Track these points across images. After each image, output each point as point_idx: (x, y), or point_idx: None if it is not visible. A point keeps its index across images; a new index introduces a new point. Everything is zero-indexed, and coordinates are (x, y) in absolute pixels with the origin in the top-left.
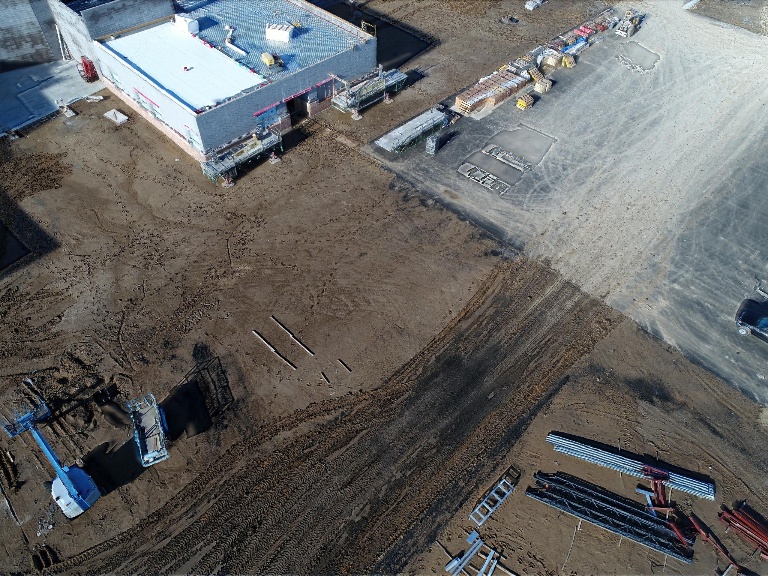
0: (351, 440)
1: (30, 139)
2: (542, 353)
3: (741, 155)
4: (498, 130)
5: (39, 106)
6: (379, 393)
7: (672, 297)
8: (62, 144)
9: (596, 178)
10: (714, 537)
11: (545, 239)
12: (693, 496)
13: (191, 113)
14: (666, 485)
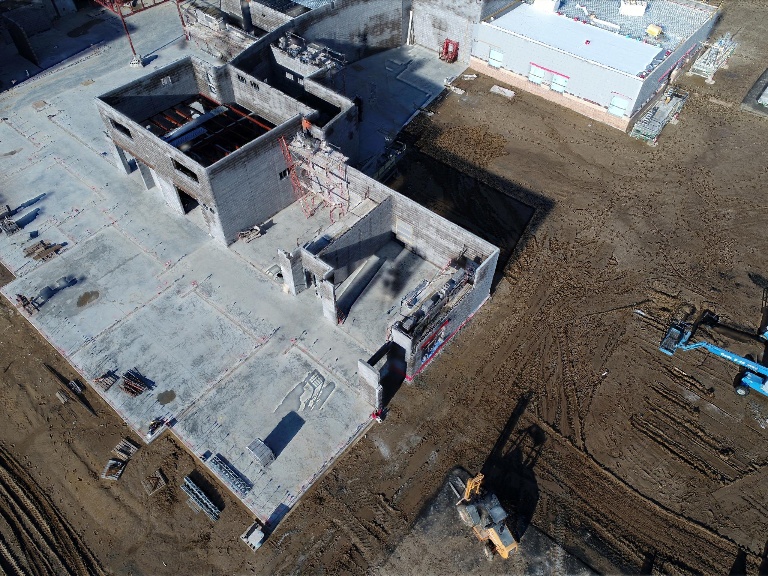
0: None
1: (443, 115)
2: None
3: None
4: None
5: (426, 86)
6: None
7: None
8: (475, 117)
9: None
10: None
11: None
12: None
13: (636, 78)
14: None
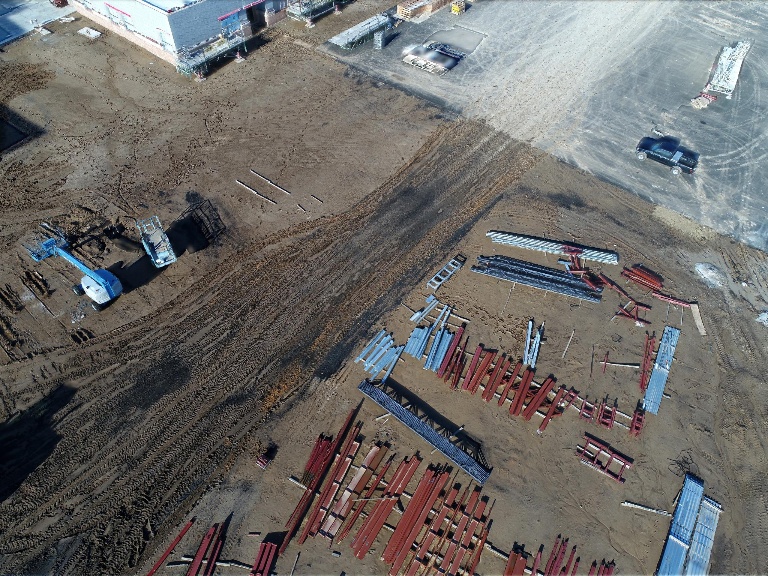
0: (327, 246)
1: (11, 53)
2: (480, 181)
3: (642, 40)
4: (436, 30)
5: (15, 27)
6: (348, 215)
7: (585, 138)
8: (42, 56)
9: (521, 61)
10: (618, 287)
11: (480, 105)
12: (602, 263)
13: (162, 13)
14: (581, 258)
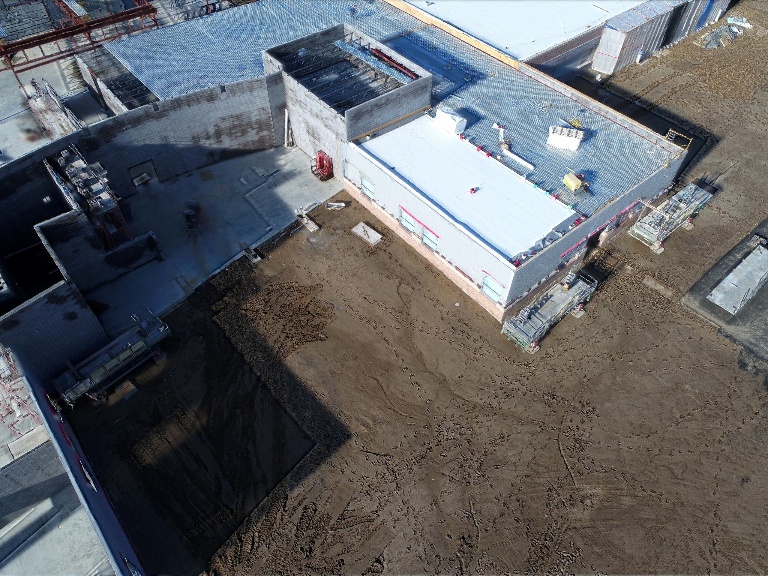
0: None
1: (273, 261)
2: None
3: None
4: None
5: (274, 213)
6: None
7: None
8: (313, 271)
9: None
10: None
11: None
12: None
13: (507, 265)
14: None
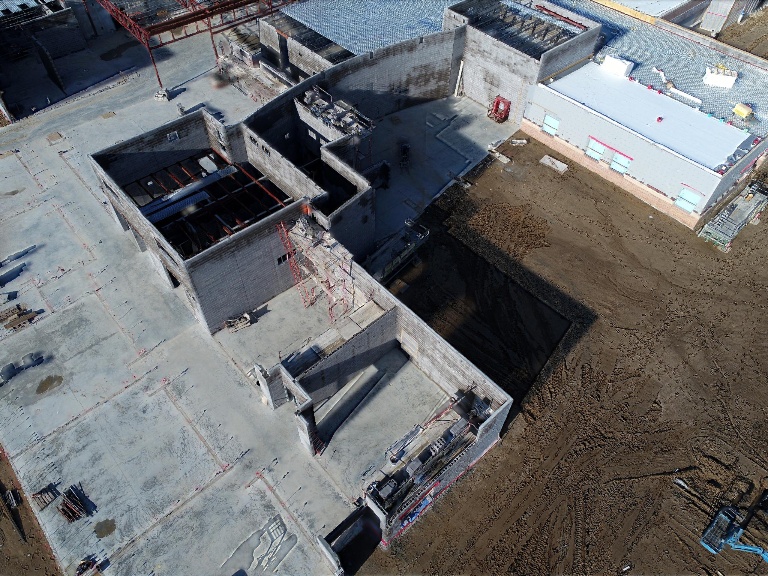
0: None
1: (481, 187)
2: None
3: None
4: None
5: (467, 149)
6: None
7: None
8: (518, 194)
9: None
10: None
11: None
12: None
13: (713, 174)
14: None
